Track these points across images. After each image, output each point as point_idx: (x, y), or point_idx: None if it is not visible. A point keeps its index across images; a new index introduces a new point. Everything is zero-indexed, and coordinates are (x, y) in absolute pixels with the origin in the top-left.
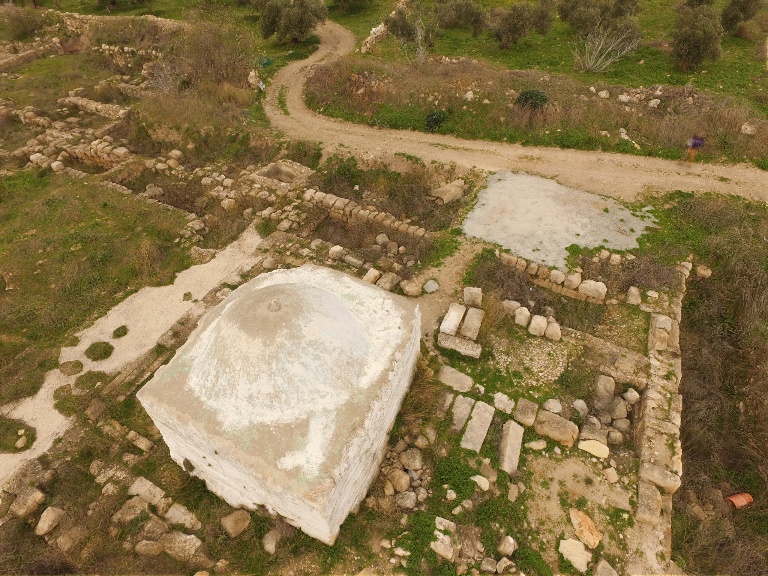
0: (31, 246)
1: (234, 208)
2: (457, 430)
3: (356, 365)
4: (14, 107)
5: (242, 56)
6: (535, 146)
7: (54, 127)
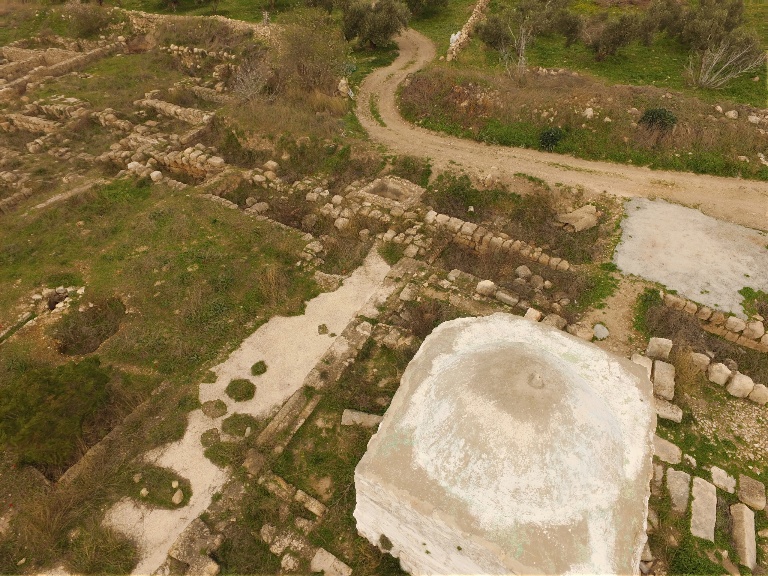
0: (146, 265)
1: (347, 228)
2: (680, 512)
3: (619, 451)
4: (92, 108)
5: (334, 63)
6: (665, 170)
7: (136, 131)
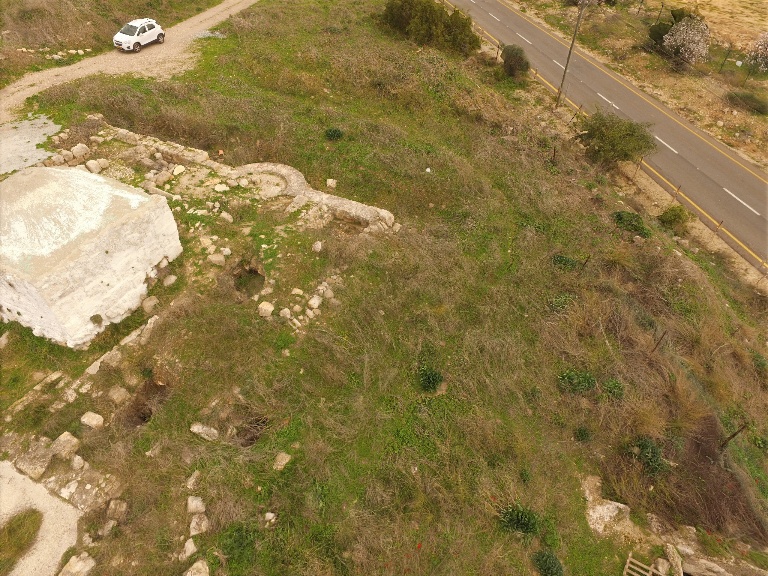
0: None
1: None
2: None
3: None
4: None
5: None
6: None
7: None
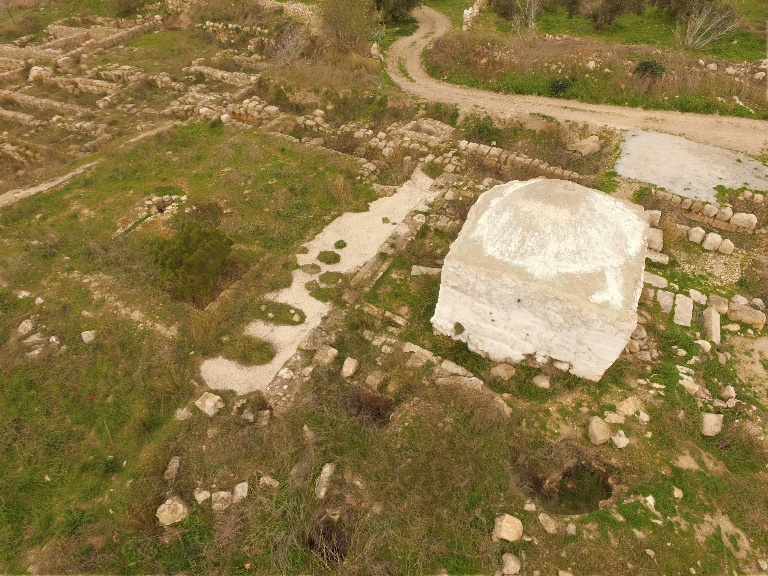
0: (233, 179)
1: (393, 156)
2: (667, 313)
3: (624, 239)
4: (147, 73)
5: (367, 29)
6: (656, 110)
7: (190, 91)
